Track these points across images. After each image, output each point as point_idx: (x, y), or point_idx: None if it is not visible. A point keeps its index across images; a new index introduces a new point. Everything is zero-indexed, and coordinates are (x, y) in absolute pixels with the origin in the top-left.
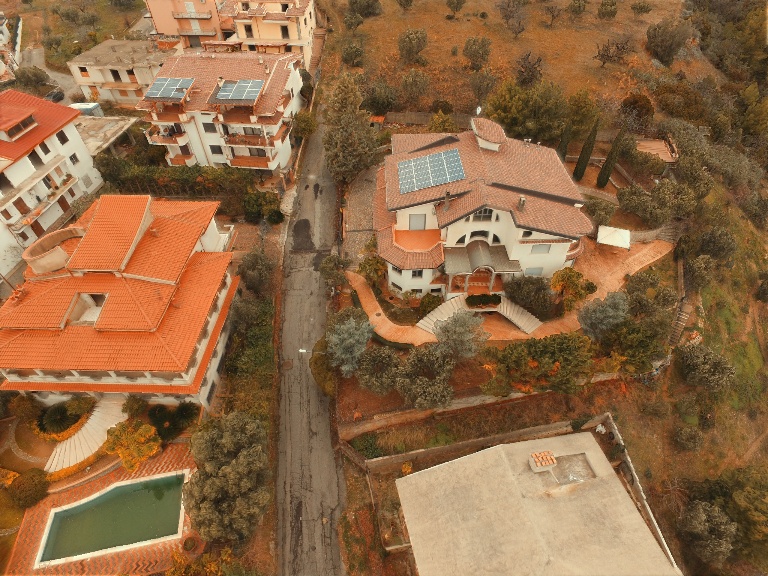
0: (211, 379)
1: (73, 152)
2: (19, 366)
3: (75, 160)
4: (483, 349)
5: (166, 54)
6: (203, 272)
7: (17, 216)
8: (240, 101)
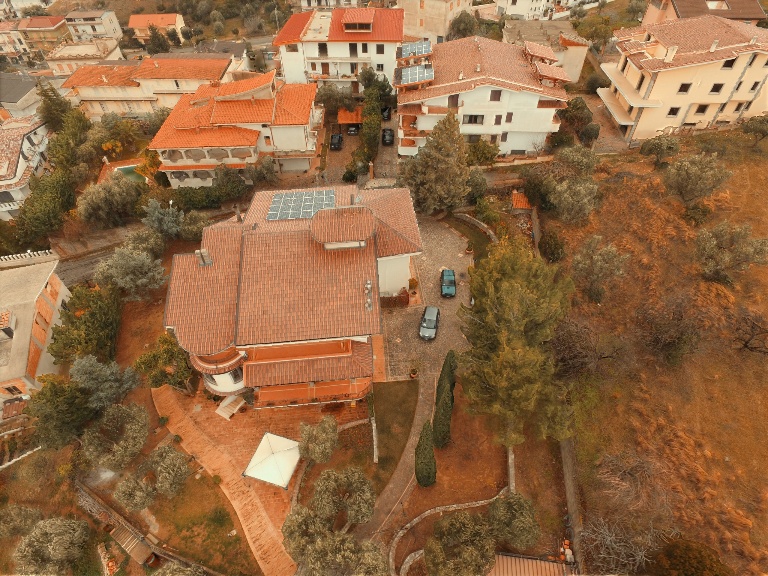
0: (190, 185)
1: (382, 63)
2: (177, 104)
3: (381, 69)
4: (111, 283)
5: (548, 46)
6: (231, 136)
7: (316, 71)
8: (399, 79)
